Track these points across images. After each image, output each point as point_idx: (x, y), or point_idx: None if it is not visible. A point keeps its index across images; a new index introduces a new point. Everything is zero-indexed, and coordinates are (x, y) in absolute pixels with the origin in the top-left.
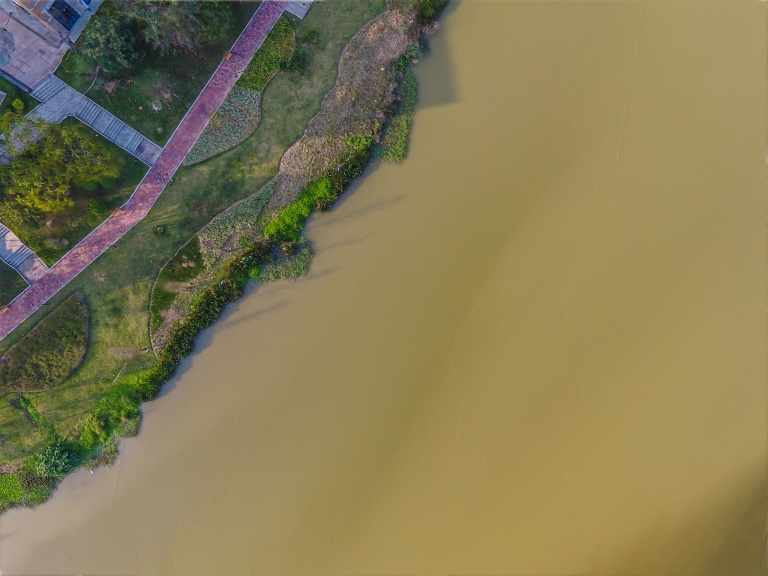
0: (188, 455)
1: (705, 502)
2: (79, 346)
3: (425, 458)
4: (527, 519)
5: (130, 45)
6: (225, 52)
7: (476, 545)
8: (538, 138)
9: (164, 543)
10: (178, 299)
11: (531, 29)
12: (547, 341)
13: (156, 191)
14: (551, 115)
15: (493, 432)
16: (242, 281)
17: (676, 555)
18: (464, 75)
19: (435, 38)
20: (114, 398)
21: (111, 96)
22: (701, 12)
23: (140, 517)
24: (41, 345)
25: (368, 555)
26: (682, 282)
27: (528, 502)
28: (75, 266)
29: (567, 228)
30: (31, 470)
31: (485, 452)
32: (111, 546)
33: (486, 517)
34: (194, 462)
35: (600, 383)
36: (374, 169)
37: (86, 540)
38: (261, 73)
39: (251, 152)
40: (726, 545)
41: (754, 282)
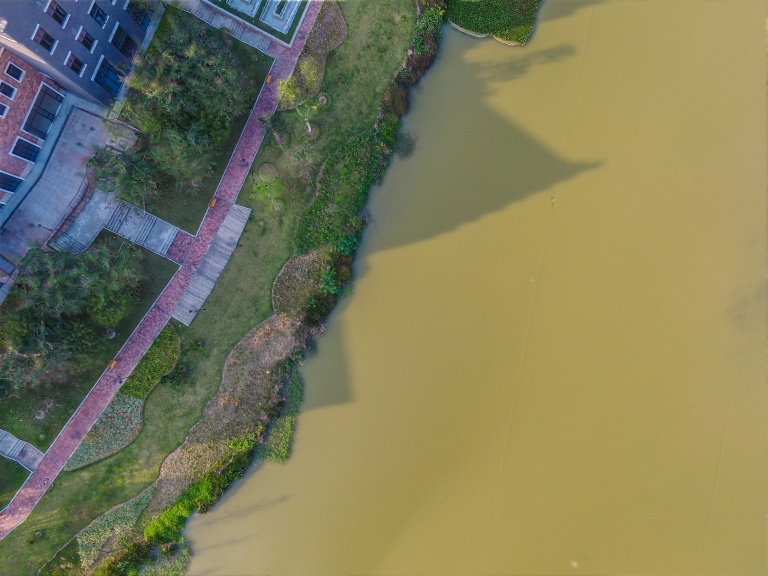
0: None
1: None
2: None
3: None
4: None
5: (2, 386)
6: (109, 362)
7: None
8: (423, 440)
9: None
10: None
11: (419, 331)
12: None
13: (36, 496)
14: (436, 418)
15: None
16: None
17: None
18: (351, 374)
19: (323, 339)
20: None
21: None
22: (591, 315)
23: None
24: None
25: None
26: None
27: None
28: None
29: (449, 534)
30: None
31: None
32: None
33: None
34: None
35: None
36: (257, 469)
37: None
38: (145, 381)
39: (131, 459)
40: None
41: None
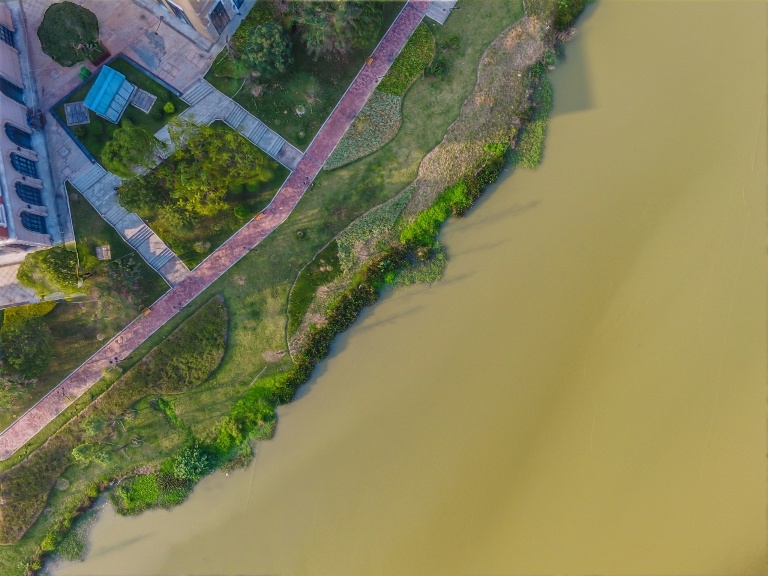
0: (323, 459)
1: None
2: (219, 349)
3: (558, 464)
4: (659, 527)
5: (289, 50)
6: (367, 57)
7: (608, 552)
8: (672, 145)
9: (298, 546)
10: (315, 303)
11: (666, 36)
12: (680, 349)
13: (297, 195)
14: (685, 122)
15: (626, 439)
16: (378, 285)
17: None
18: (598, 82)
19: (570, 44)
20: (251, 401)
21: (257, 100)
22: None
23: (275, 520)
24: (182, 347)
25: (501, 561)
26: None
27: (660, 510)
28: (216, 269)
29: (701, 236)
30: (168, 472)
31: (618, 459)
32: (245, 548)
33: (619, 524)
34: (328, 466)
35: (732, 391)
36: (509, 175)
37: (221, 542)
38: (402, 78)
39: (391, 157)
40: None
41: None
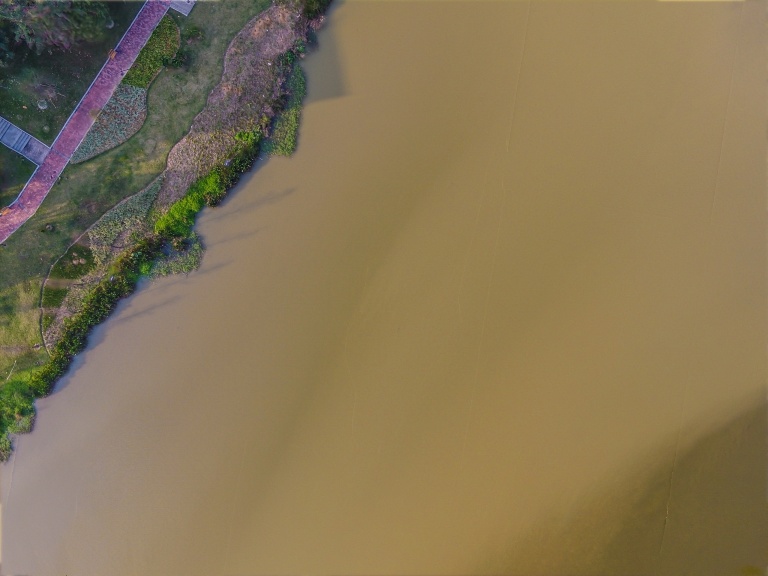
0: (83, 451)
1: (601, 490)
2: None
3: (319, 450)
4: (422, 509)
5: (3, 45)
6: (109, 50)
7: (371, 536)
8: (428, 129)
9: (60, 539)
10: (69, 296)
11: (419, 21)
12: (439, 331)
13: (44, 189)
14: (440, 106)
15: (387, 423)
16: (133, 277)
17: (573, 543)
18: (353, 68)
19: (323, 32)
20: (7, 395)
21: None
22: (590, 0)
23: (36, 513)
24: None
25: (263, 548)
26: (574, 270)
27: (423, 492)
28: None
29: (458, 218)
30: None
31: (379, 443)
32: (8, 542)
33: (381, 508)
34: (88, 458)
35: (494, 372)
36: (264, 163)
37: None
38: (146, 70)
39: (138, 149)
40: (624, 533)
41: (647, 269)
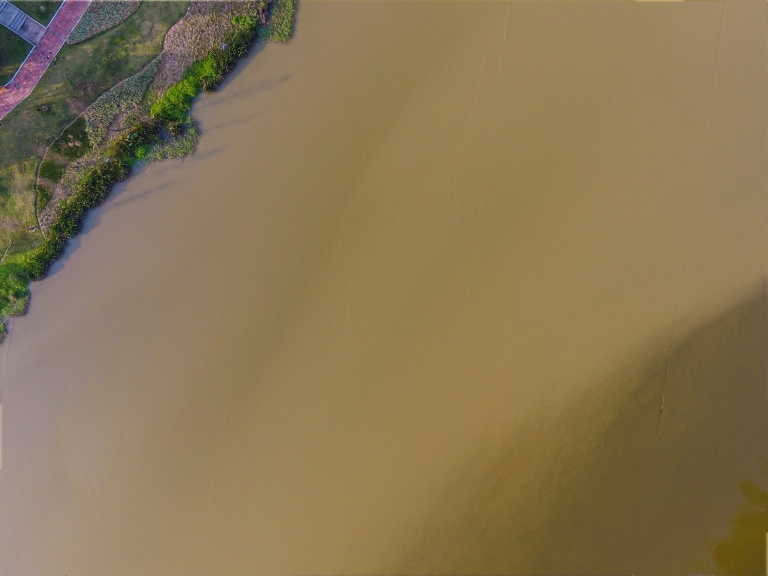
0: (77, 334)
1: (596, 379)
2: None
3: (313, 336)
4: (417, 396)
5: None
6: None
7: (366, 423)
8: (425, 17)
9: (54, 422)
10: (65, 178)
11: None
12: (435, 219)
13: (40, 70)
14: None
15: (382, 310)
16: (129, 161)
17: (568, 432)
18: None
19: None
20: (2, 277)
21: None
22: None
23: (29, 396)
24: None
25: (257, 433)
26: (571, 159)
27: (418, 379)
28: None
29: (455, 106)
30: None
31: (374, 330)
32: (1, 425)
33: (375, 394)
34: (83, 341)
35: (490, 261)
36: (261, 49)
37: None
38: None
39: (134, 30)
40: (619, 423)
41: (644, 158)
